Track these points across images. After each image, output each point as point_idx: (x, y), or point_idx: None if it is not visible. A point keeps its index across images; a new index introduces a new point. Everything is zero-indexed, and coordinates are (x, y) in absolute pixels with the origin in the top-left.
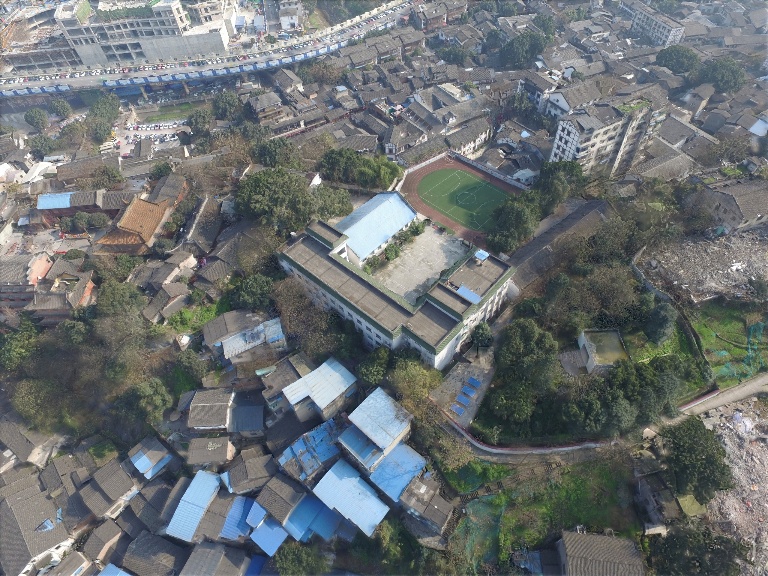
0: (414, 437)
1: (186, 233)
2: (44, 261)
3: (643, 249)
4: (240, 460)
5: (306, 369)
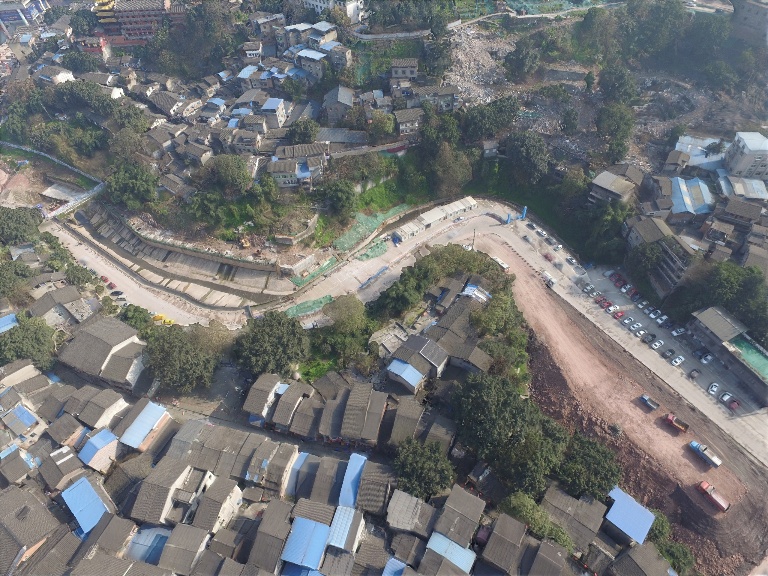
0: (339, 40)
1: None
2: (169, 2)
3: None
4: None
5: None
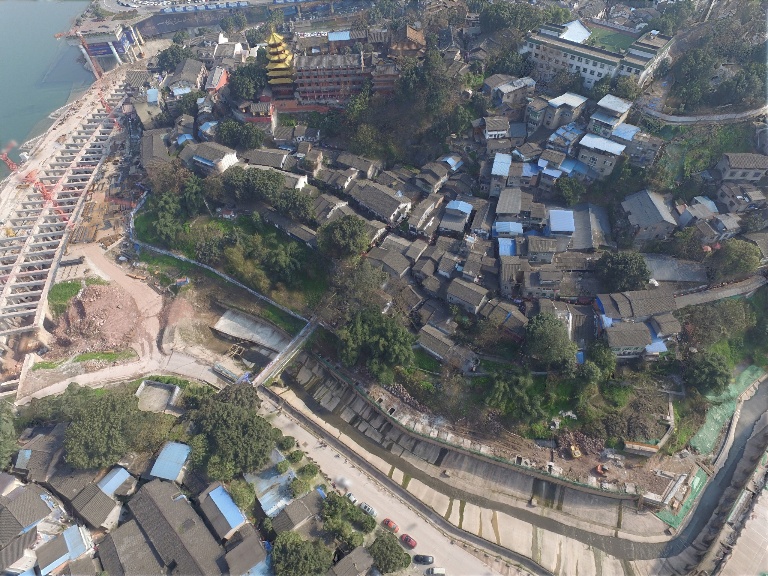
0: (629, 121)
1: (447, 43)
2: None
3: (746, 33)
4: None
5: None
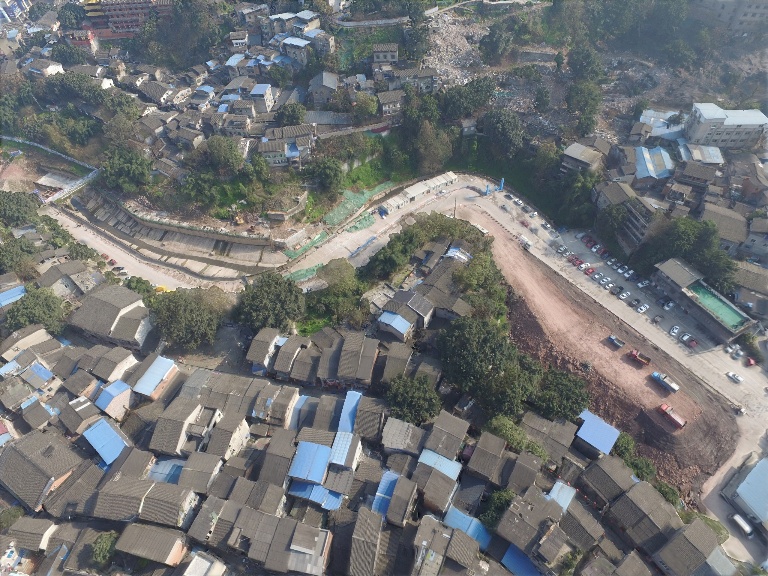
0: None
1: None
2: None
3: None
4: None
5: None
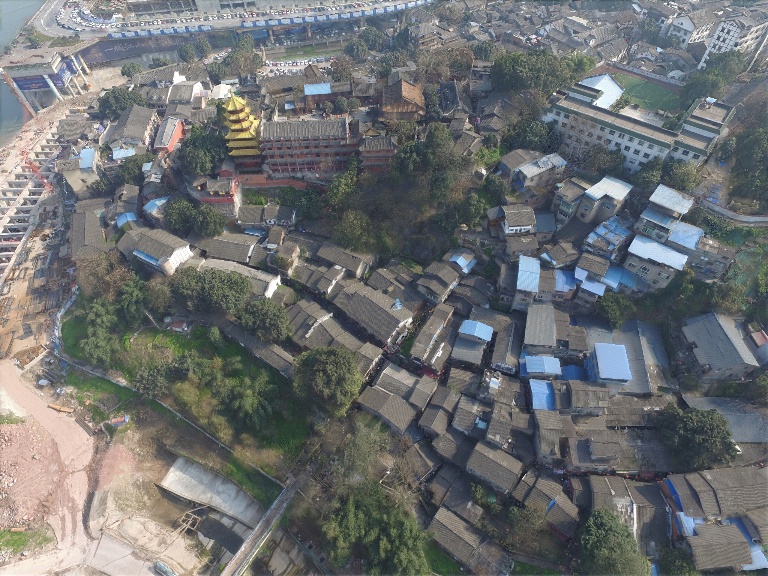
0: (686, 218)
1: (451, 103)
2: None
3: None
4: (545, 250)
5: (587, 185)
